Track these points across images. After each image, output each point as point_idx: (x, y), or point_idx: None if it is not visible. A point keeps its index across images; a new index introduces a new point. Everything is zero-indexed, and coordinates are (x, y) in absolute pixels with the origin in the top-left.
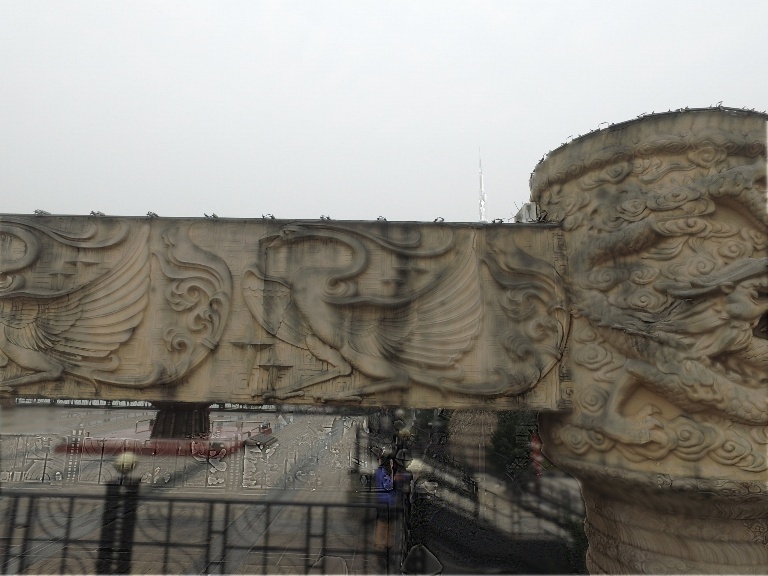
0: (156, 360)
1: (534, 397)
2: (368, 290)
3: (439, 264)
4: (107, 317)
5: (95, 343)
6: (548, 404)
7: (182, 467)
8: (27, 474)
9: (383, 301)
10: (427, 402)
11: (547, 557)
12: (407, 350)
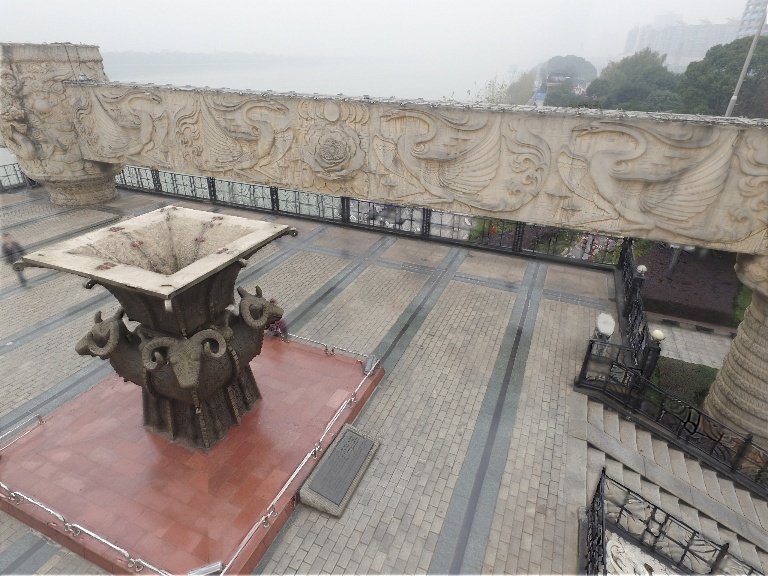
0: (502, 198)
1: (739, 246)
2: (642, 169)
3: (701, 155)
4: (476, 172)
5: (470, 186)
6: (748, 251)
7: (487, 234)
8: (402, 226)
9: (651, 180)
10: (663, 239)
11: (717, 307)
12: (659, 210)
